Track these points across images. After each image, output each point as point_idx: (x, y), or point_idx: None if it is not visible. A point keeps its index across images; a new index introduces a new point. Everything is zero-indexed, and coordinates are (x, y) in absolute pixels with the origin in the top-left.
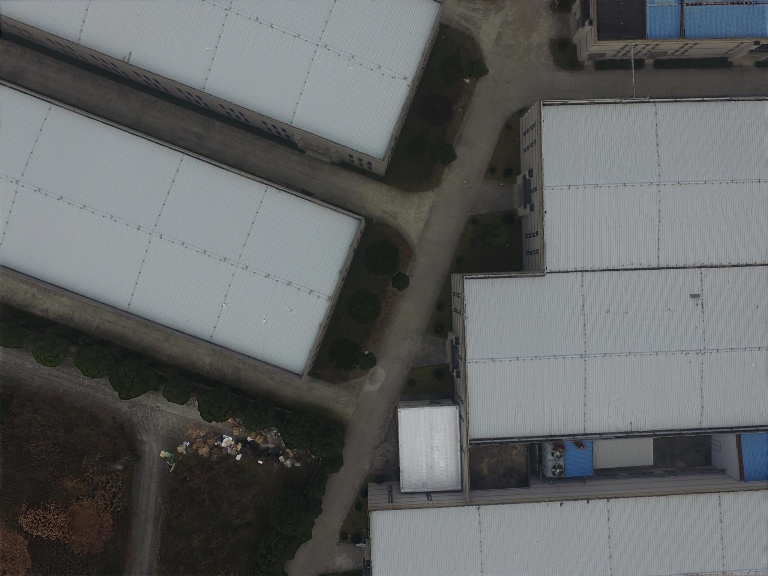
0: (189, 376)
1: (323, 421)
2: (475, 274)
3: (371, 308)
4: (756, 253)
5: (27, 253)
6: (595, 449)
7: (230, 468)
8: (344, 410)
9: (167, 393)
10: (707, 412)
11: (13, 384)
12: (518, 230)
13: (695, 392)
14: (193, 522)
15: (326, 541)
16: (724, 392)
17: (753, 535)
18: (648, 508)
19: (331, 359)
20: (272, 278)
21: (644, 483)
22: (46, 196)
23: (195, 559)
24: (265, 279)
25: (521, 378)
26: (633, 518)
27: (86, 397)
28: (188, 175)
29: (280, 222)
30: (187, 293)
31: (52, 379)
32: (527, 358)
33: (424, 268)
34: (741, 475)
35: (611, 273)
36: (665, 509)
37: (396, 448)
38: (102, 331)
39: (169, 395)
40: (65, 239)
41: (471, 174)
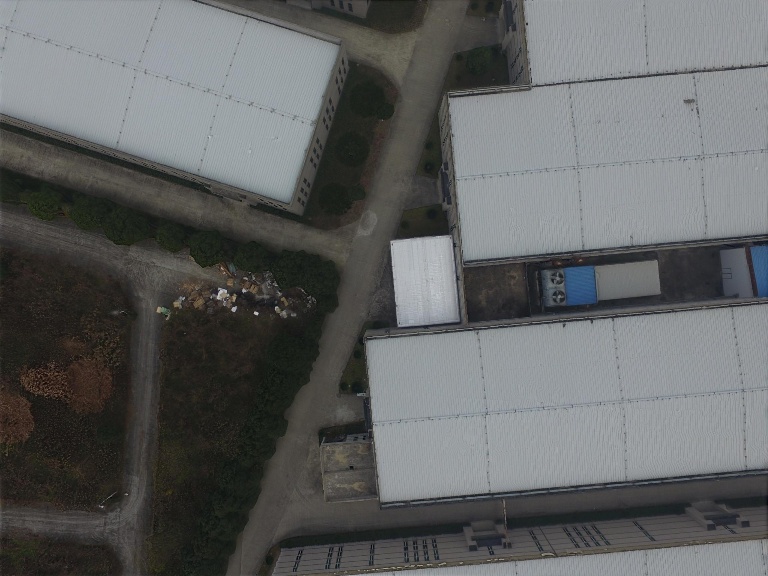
0: (182, 228)
1: (315, 256)
2: (459, 90)
3: (359, 148)
4: (750, 54)
5: (18, 98)
6: (597, 276)
7: (226, 321)
8: (338, 257)
9: (159, 236)
10: (712, 222)
11: (12, 247)
12: (504, 64)
13: (697, 201)
14: (192, 377)
15: (326, 393)
16: (728, 199)
17: None
18: (656, 326)
19: (322, 204)
20: (256, 106)
21: (651, 307)
22: (34, 40)
23: (195, 413)
24: (249, 107)
25: (513, 194)
26: (641, 337)
27: (82, 256)
28: (170, 12)
29: (261, 52)
30: (173, 127)
31: (49, 240)
32: (518, 173)
33: (410, 108)
34: (754, 291)
35: (599, 83)
36: (675, 326)
37: (392, 293)
38: (96, 190)
39: (161, 238)
40: (54, 81)
41: (452, 12)
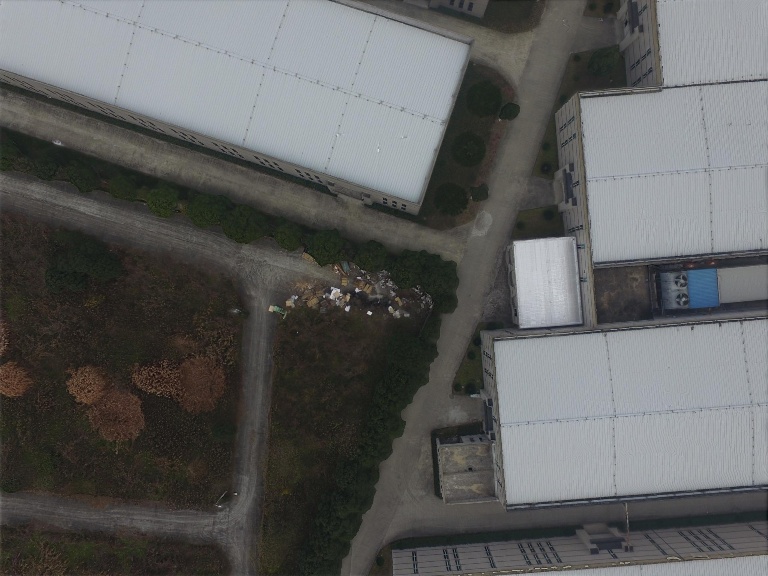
0: None
1: (438, 256)
2: None
3: (477, 148)
4: None
5: (144, 94)
6: (719, 279)
7: (339, 320)
8: (452, 257)
9: (280, 234)
10: None
11: (123, 244)
12: (621, 66)
13: None
14: (304, 377)
15: (439, 394)
16: None
17: None
18: None
19: (437, 204)
20: (385, 105)
21: None
22: (162, 35)
23: (308, 413)
24: (378, 106)
25: (643, 196)
26: None
27: (194, 254)
28: (298, 9)
29: (390, 50)
30: (301, 125)
31: (161, 237)
32: (649, 174)
33: (527, 109)
34: None
35: (730, 85)
36: None
37: (507, 294)
38: (209, 187)
39: (282, 236)
40: (181, 77)
41: (570, 12)
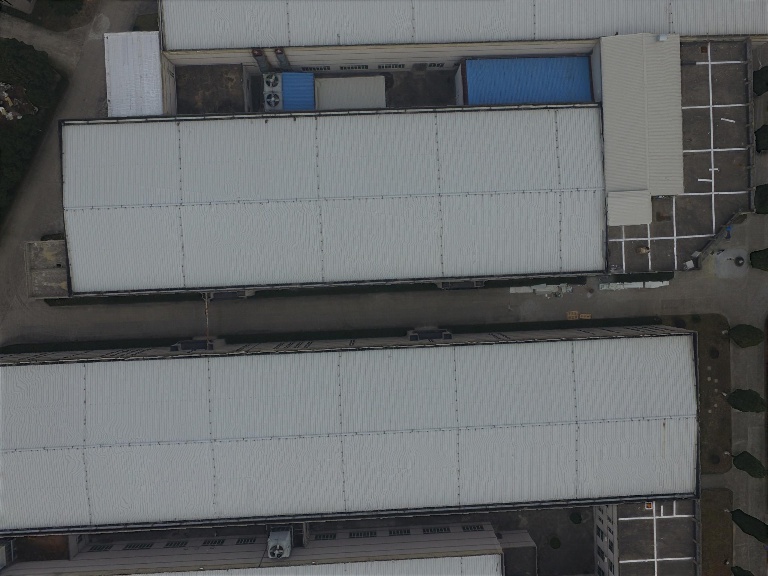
0: None
1: (24, 43)
2: None
3: None
4: None
5: None
6: (318, 85)
7: None
8: (68, 60)
9: None
10: (419, 25)
11: None
12: None
13: (405, 2)
14: None
15: (51, 199)
16: (436, 3)
17: (472, 157)
18: (359, 127)
19: (51, 3)
20: None
21: None
22: None
23: None
24: None
25: None
26: (343, 137)
27: None
28: None
29: None
30: None
31: None
32: None
33: None
34: (465, 103)
35: None
36: (377, 128)
37: None
38: None
39: None
40: None
41: None
